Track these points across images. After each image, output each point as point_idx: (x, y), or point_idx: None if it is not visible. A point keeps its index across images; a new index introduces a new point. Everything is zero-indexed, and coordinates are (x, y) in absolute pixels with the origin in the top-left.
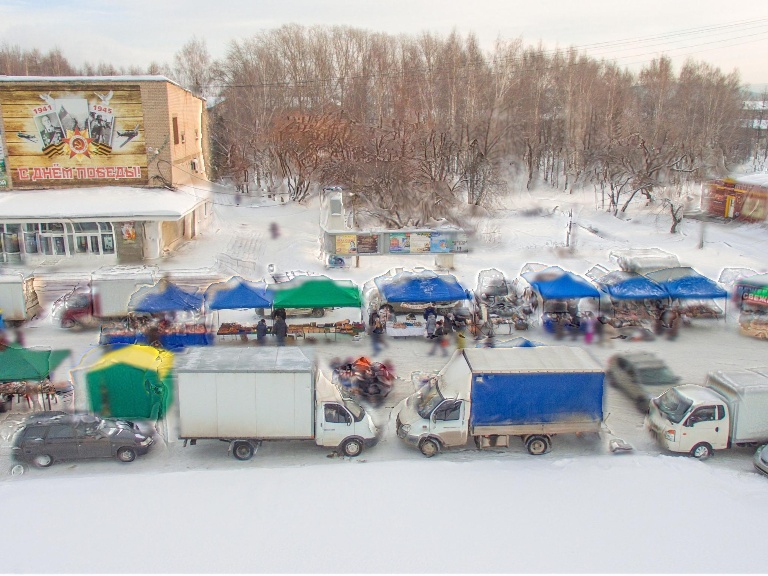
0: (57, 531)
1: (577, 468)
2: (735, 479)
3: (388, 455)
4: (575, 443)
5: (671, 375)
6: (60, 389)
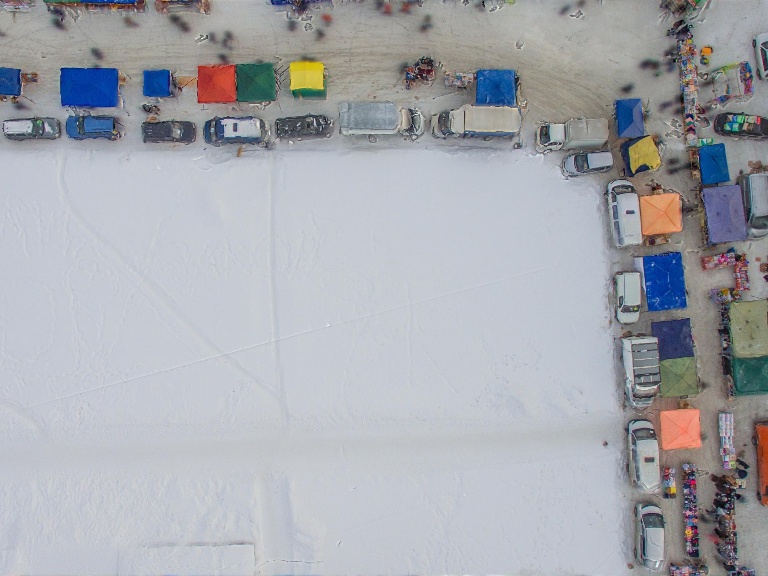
0: (322, 184)
1: (495, 162)
2: (548, 172)
3: (428, 139)
4: (502, 142)
5: (577, 73)
6: (275, 67)
